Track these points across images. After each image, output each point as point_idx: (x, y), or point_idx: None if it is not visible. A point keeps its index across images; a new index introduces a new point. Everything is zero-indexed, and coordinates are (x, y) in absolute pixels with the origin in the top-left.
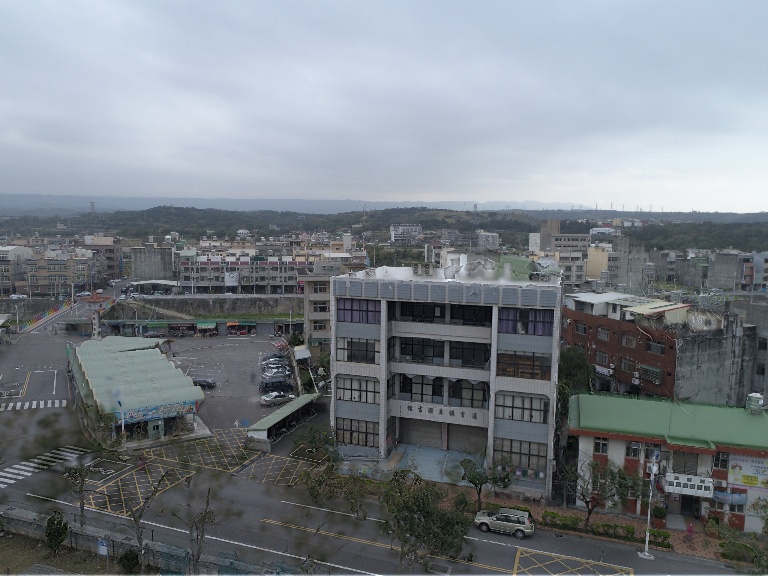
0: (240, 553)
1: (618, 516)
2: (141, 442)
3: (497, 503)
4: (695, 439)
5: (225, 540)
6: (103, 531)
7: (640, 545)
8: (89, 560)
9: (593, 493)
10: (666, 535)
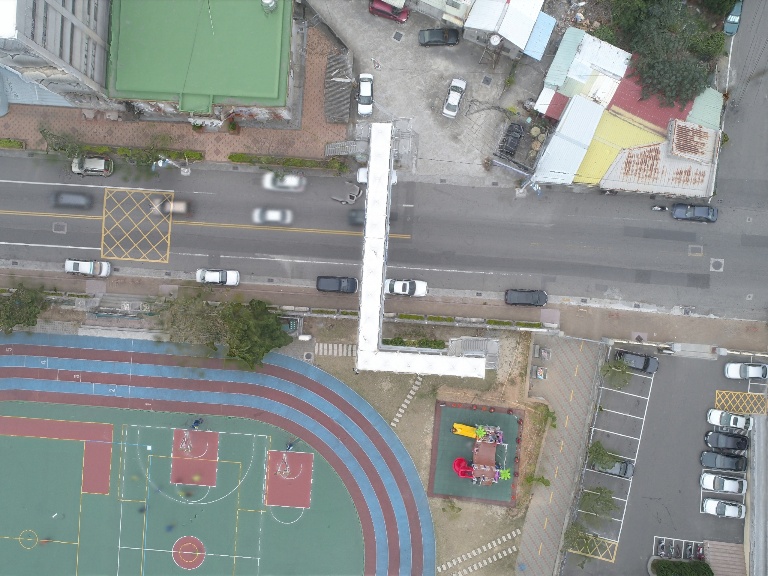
0: None
1: (173, 126)
2: None
3: (88, 129)
4: (202, 94)
5: None
6: None
7: (183, 162)
8: None
9: (152, 111)
10: (196, 157)
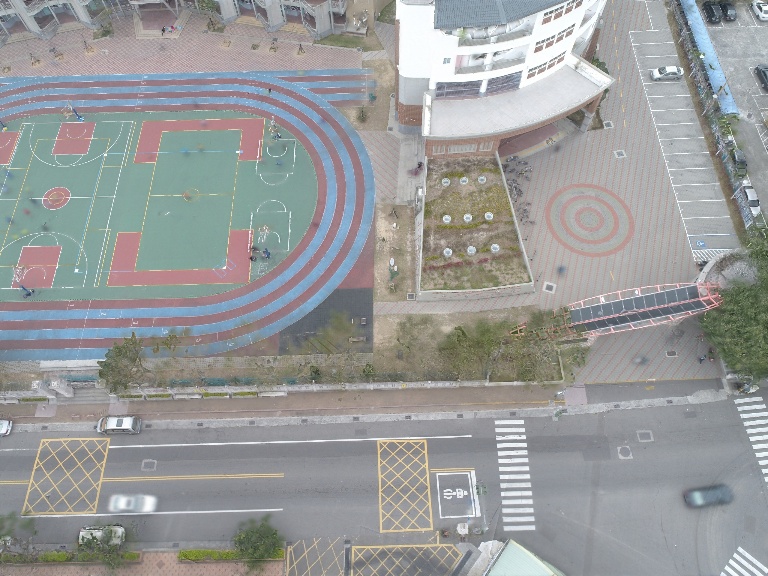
0: (278, 432)
1: None
2: (479, 570)
3: None
4: None
5: (295, 442)
6: (378, 419)
7: None
8: (349, 379)
9: None
10: None
